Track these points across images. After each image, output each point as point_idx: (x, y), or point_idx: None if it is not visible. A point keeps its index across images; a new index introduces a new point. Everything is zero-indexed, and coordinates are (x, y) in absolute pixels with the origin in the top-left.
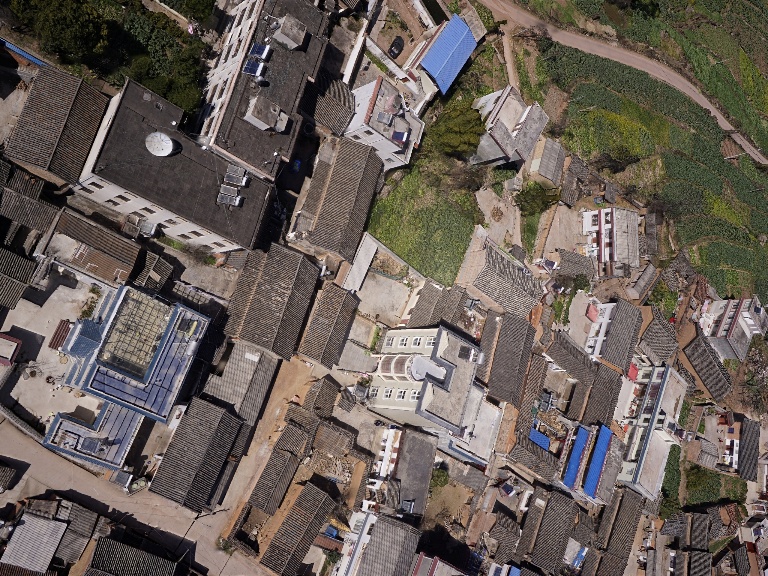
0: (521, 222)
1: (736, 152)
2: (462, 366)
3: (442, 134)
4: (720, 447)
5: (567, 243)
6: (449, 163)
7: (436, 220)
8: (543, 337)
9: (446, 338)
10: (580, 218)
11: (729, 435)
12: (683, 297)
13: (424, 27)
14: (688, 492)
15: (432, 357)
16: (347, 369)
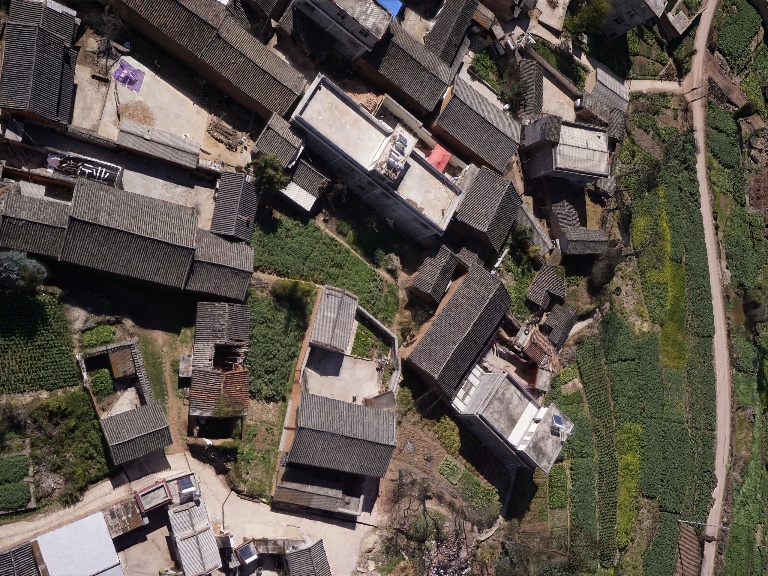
0: None
1: None
2: None
3: None
4: None
5: None
6: None
7: None
8: None
9: None
10: None
11: None
12: None
13: None
14: (266, 295)
15: None
16: None
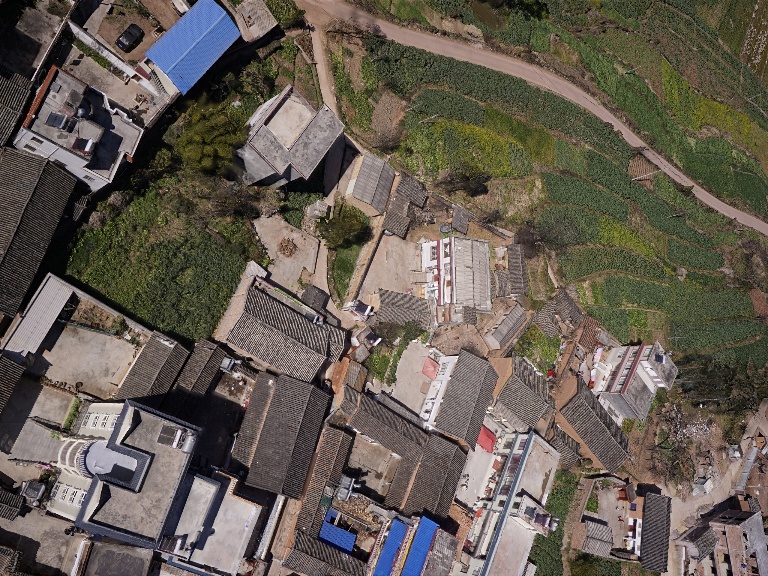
0: (329, 257)
1: (650, 172)
2: (165, 454)
3: (185, 145)
4: (621, 528)
5: (399, 282)
6: (209, 183)
7: (181, 256)
8: (344, 403)
9: (129, 417)
10: (418, 251)
11: (631, 513)
12: (567, 344)
13: (182, 15)
14: None
15: (109, 444)
16: (23, 458)
